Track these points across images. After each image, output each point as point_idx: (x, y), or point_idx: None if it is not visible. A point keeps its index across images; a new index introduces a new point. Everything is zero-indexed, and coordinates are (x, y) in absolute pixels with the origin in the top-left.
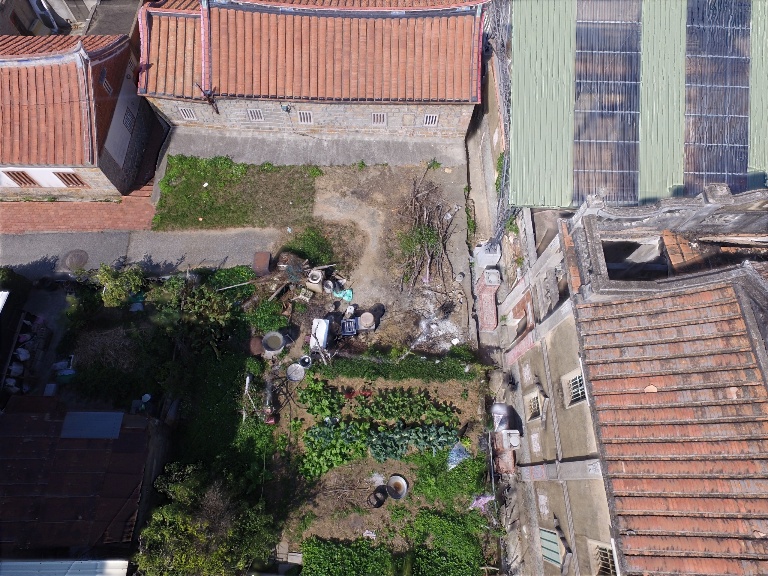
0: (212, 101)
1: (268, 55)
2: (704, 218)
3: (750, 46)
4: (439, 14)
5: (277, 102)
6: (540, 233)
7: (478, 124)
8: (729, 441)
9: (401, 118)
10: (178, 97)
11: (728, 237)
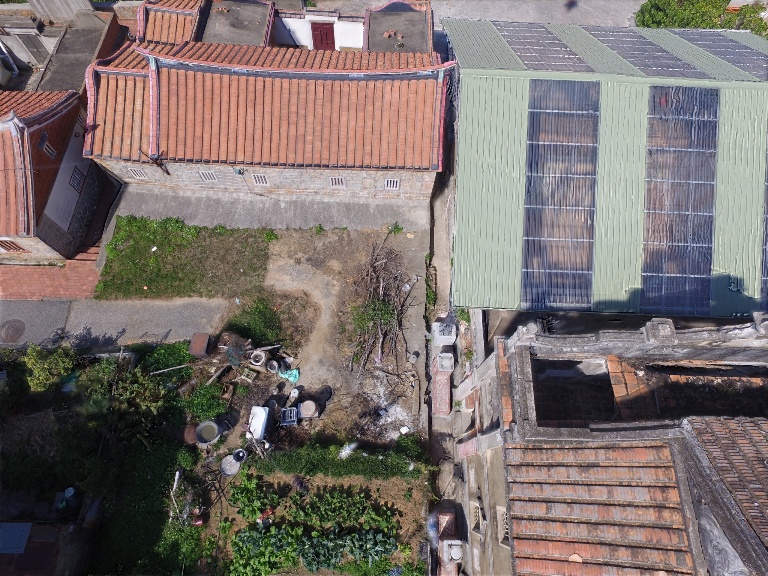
0: (161, 164)
1: (219, 118)
2: (649, 349)
3: (716, 138)
4: (399, 78)
5: (229, 166)
6: (493, 323)
7: (446, 183)
8: None
9: (360, 182)
10: (125, 160)
11: None
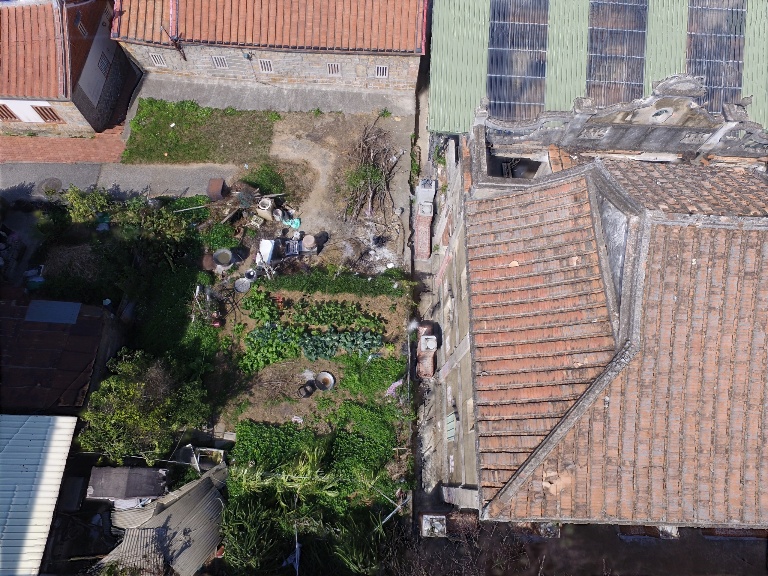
0: (179, 47)
1: (231, 5)
2: (579, 131)
3: None
4: None
5: (239, 49)
6: None
7: None
8: (566, 298)
9: (354, 69)
10: (148, 42)
11: (607, 154)
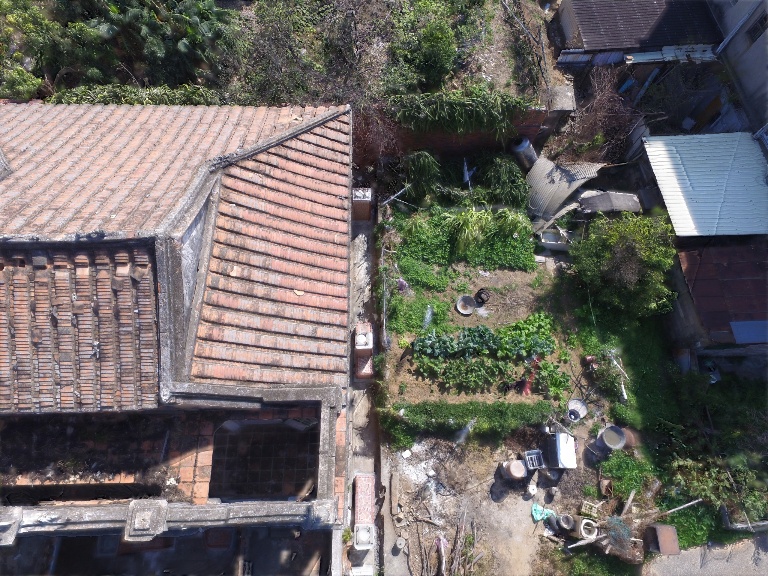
0: None
1: None
2: None
3: None
4: None
5: None
6: None
7: None
8: (253, 236)
9: None
10: None
11: None
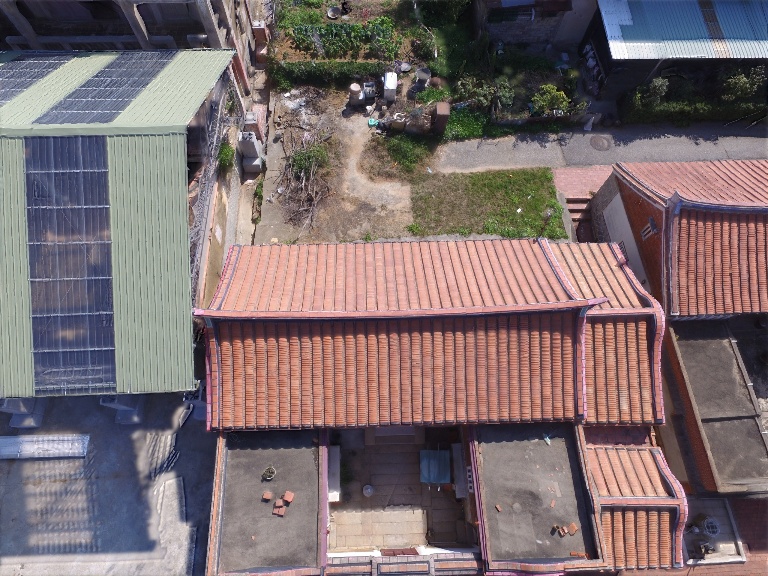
0: None
1: (485, 274)
2: None
3: None
4: None
5: None
6: None
7: None
8: None
9: None
10: None
11: None
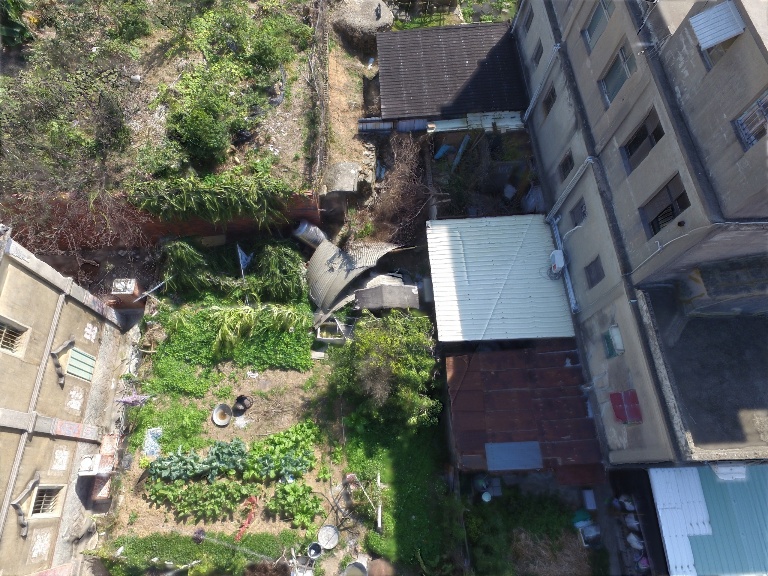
0: None
1: None
2: None
3: None
4: None
5: None
6: None
7: None
8: None
9: None
10: None
11: None
